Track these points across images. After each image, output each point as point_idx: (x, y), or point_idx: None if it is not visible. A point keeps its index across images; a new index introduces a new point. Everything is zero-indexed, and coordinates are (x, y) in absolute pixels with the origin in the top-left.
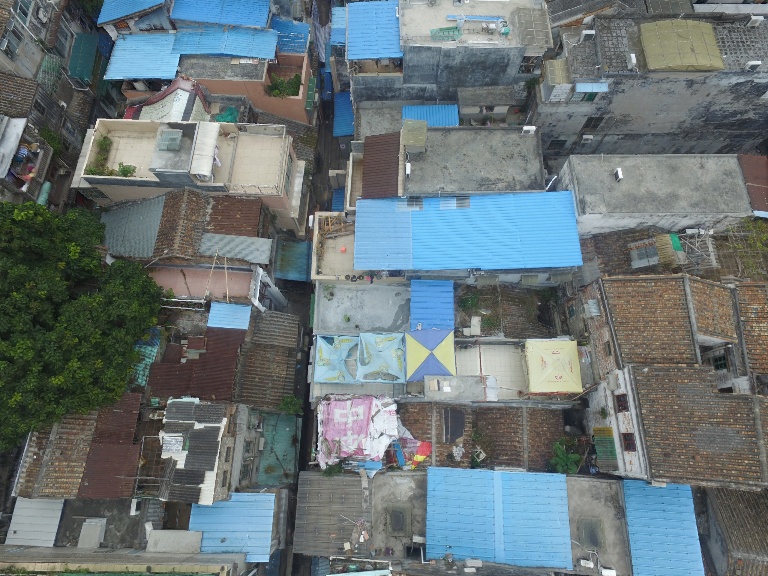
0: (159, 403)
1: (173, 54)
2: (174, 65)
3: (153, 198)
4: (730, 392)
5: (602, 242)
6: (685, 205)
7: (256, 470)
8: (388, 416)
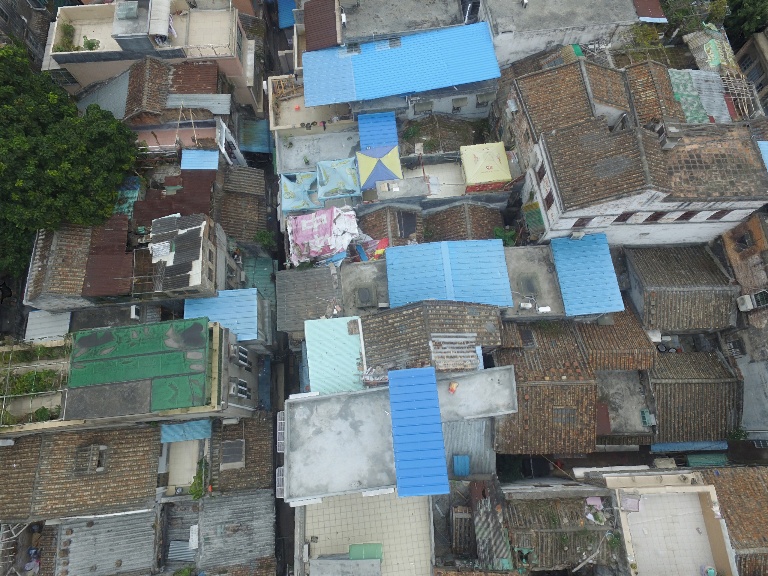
0: (145, 230)
1: None
2: None
3: (119, 76)
4: None
5: (520, 68)
6: (582, 20)
7: None
8: (348, 219)
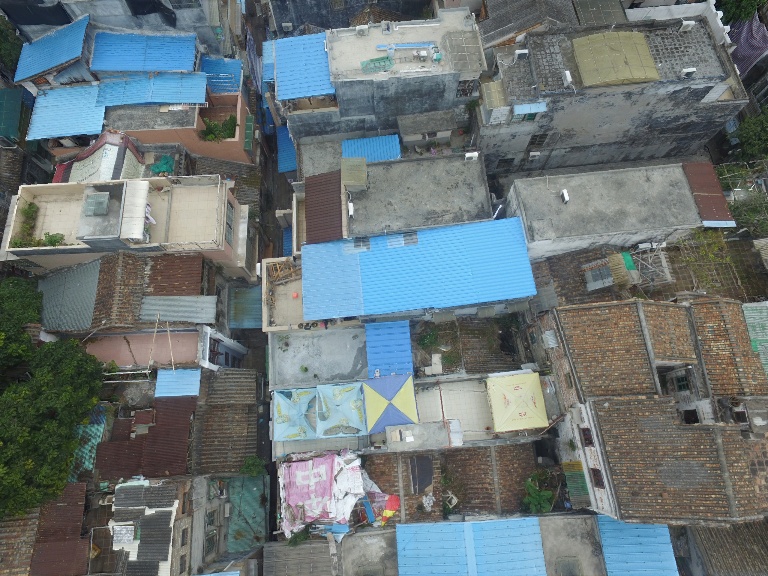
0: (108, 487)
1: (98, 107)
2: (99, 119)
3: (88, 263)
4: (695, 415)
5: (556, 264)
6: (634, 222)
7: (224, 538)
8: (352, 473)
